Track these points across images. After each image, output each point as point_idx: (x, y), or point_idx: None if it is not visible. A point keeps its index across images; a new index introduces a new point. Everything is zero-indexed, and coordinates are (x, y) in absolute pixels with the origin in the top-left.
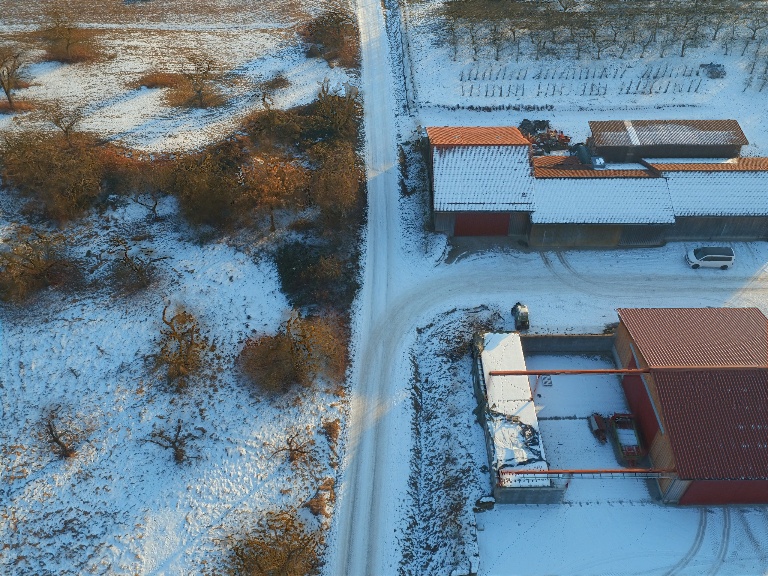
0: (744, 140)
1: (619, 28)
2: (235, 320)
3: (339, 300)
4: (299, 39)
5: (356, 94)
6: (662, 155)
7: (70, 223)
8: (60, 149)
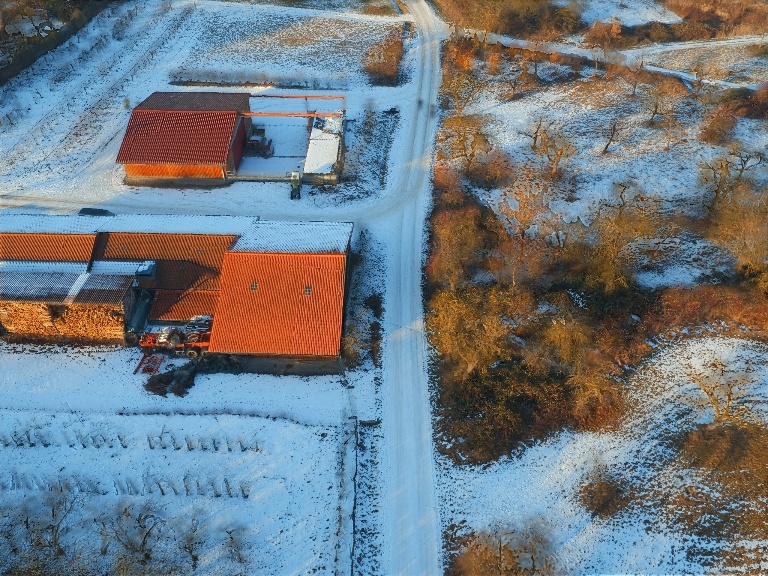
0: None
1: None
2: None
3: None
4: None
5: None
6: None
7: None
8: None
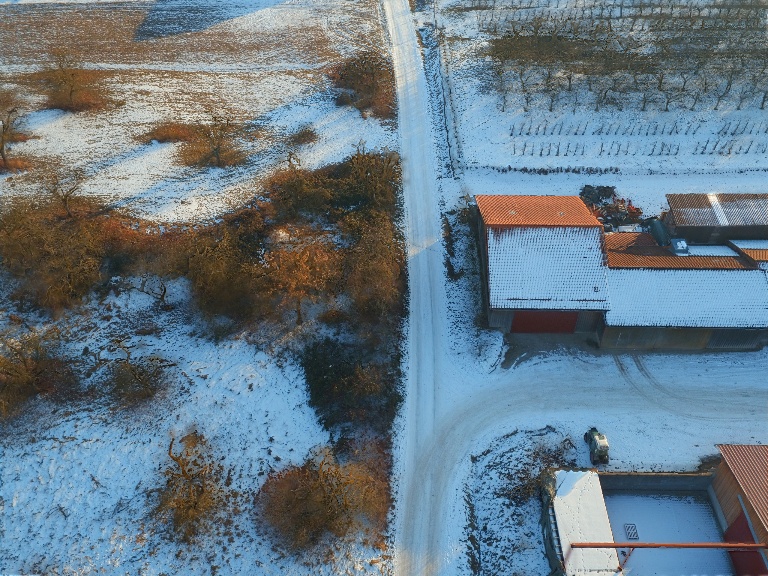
0: None
1: (687, 73)
2: (255, 443)
3: (378, 417)
4: (328, 83)
5: (396, 160)
6: (753, 236)
7: (66, 312)
8: (58, 218)
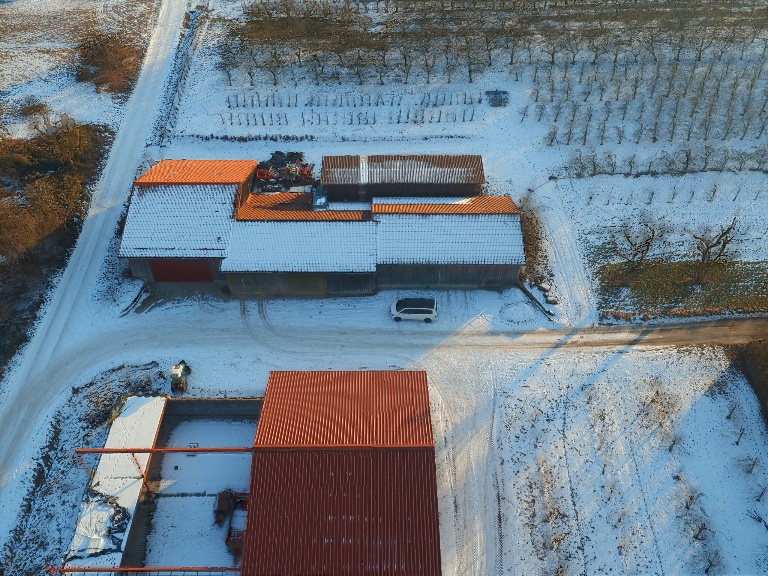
0: (481, 178)
1: (417, 50)
2: None
3: None
4: (78, 61)
5: (73, 126)
6: (397, 193)
7: None
8: None
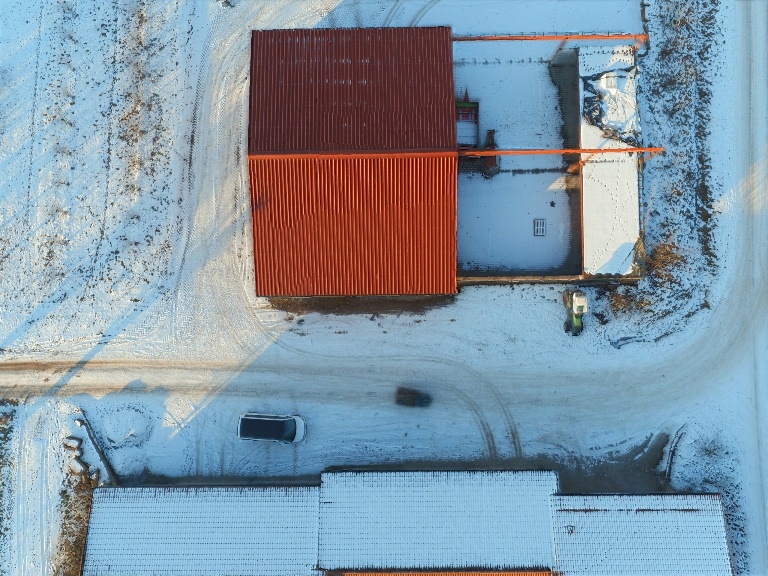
0: None
1: None
2: None
3: None
4: None
5: None
6: None
7: None
8: None
